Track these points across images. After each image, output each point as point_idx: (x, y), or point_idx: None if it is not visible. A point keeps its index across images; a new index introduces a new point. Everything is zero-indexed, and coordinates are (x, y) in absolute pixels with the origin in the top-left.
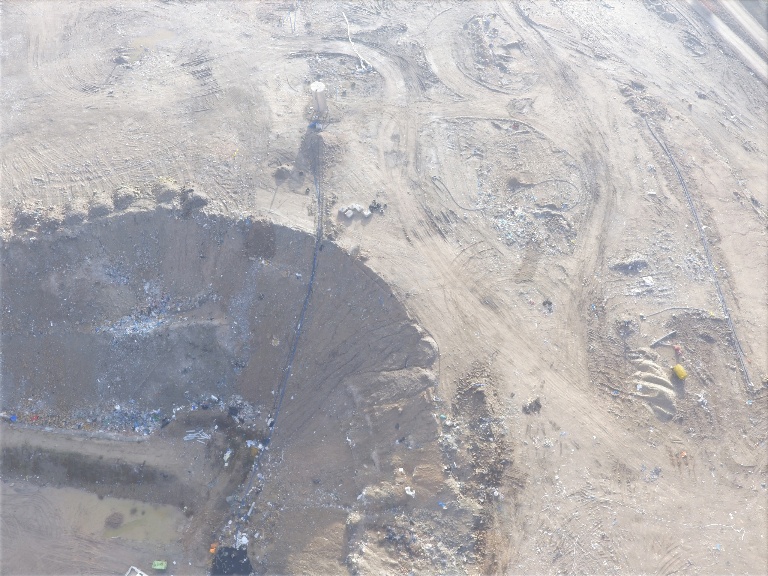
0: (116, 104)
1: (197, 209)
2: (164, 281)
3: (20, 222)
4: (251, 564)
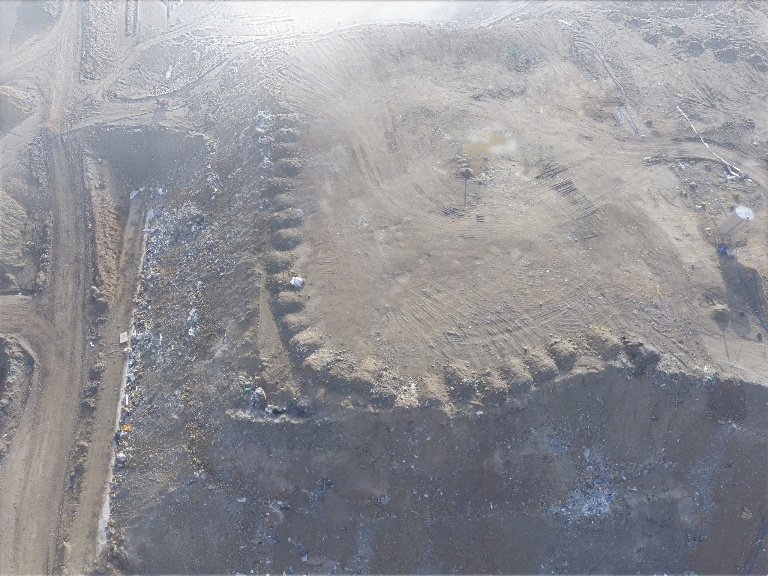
0: (492, 231)
1: (652, 366)
2: (605, 446)
3: (460, 393)
4: None
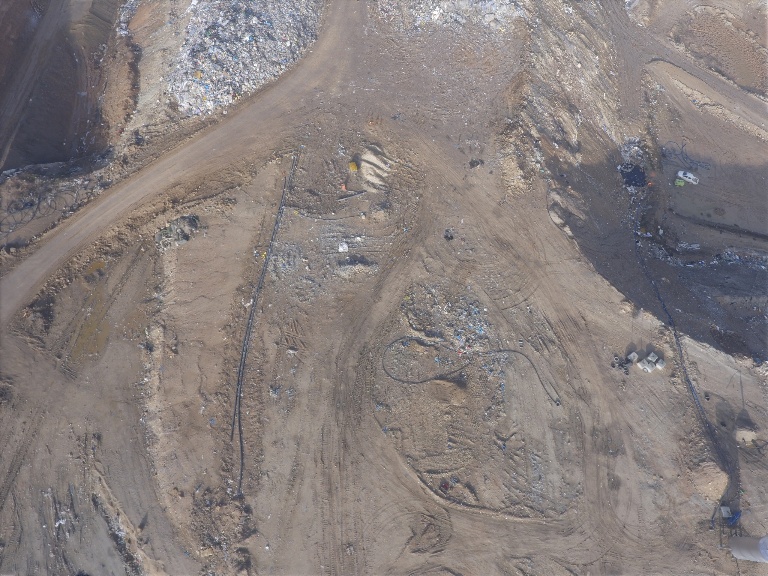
0: None
1: None
2: None
3: None
4: None
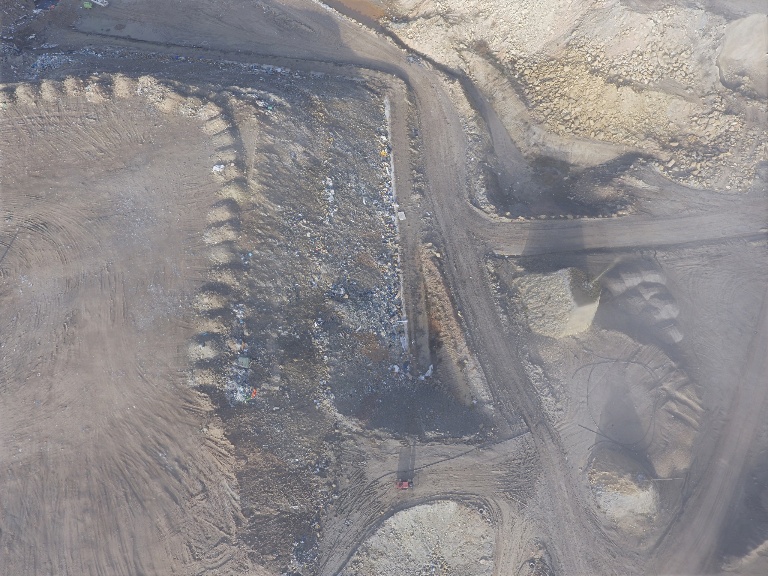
0: (4, 201)
1: None
2: None
3: (104, 82)
4: (34, 3)
